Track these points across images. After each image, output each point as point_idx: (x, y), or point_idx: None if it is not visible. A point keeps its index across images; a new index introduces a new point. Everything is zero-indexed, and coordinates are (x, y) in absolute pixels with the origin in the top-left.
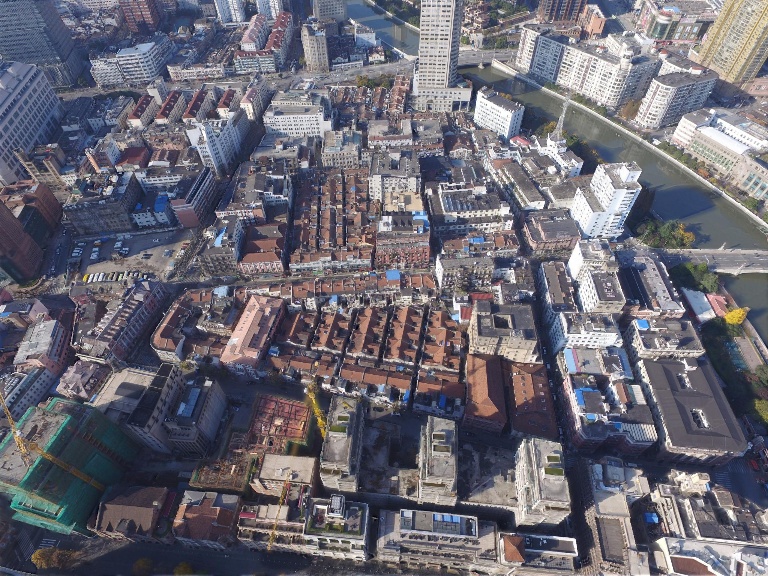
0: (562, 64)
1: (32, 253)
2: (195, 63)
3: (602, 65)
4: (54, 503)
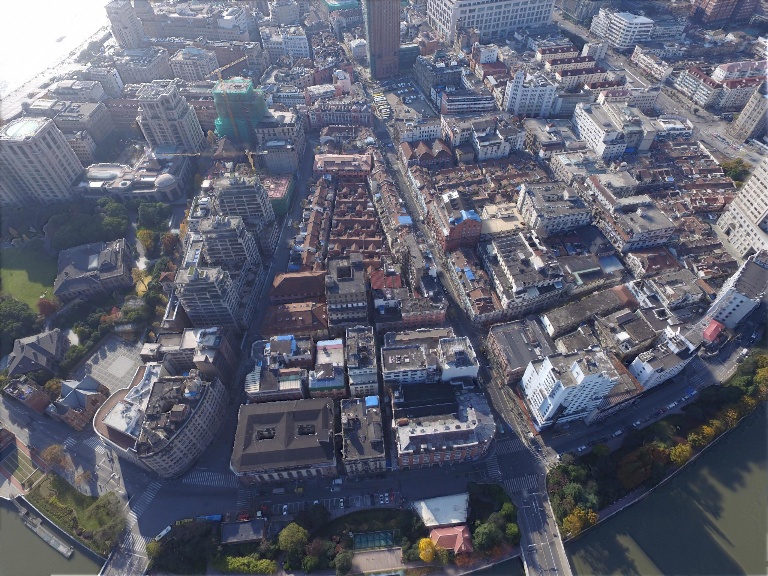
0: None
1: (389, 68)
2: (666, 58)
3: None
4: (218, 115)
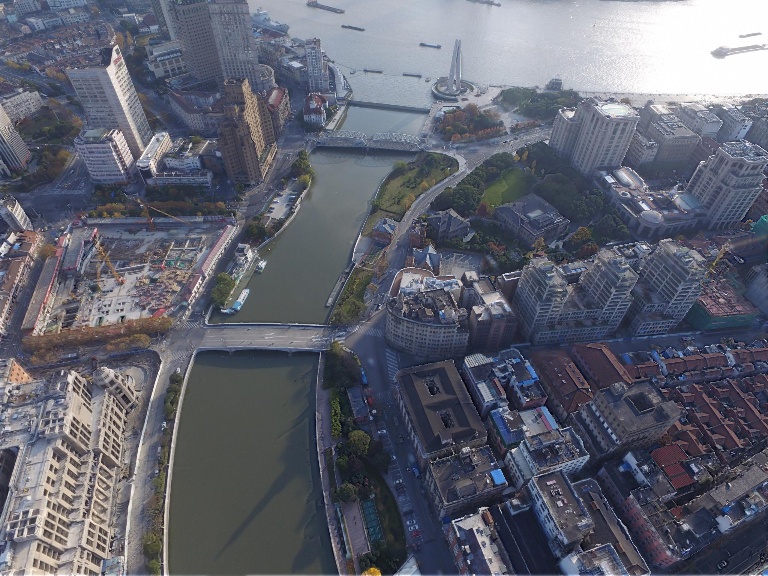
0: None
1: None
2: None
3: None
4: None
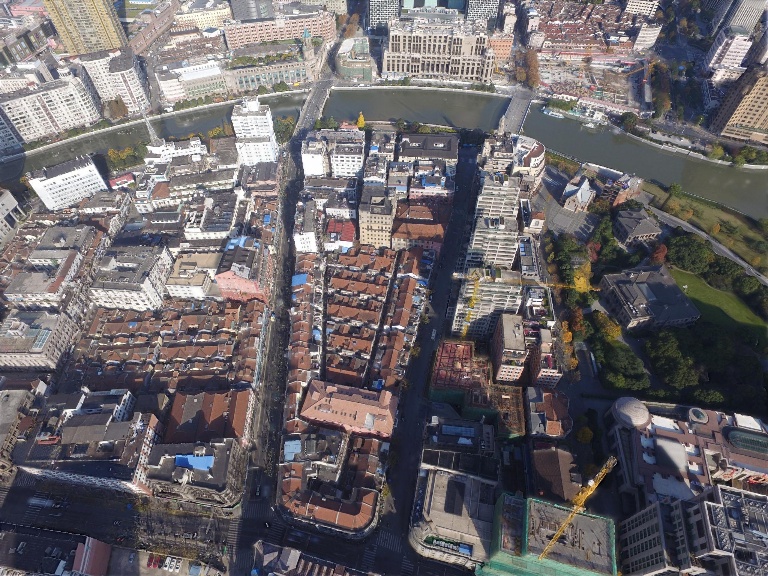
0: (13, 122)
1: None
2: None
3: (56, 94)
4: None
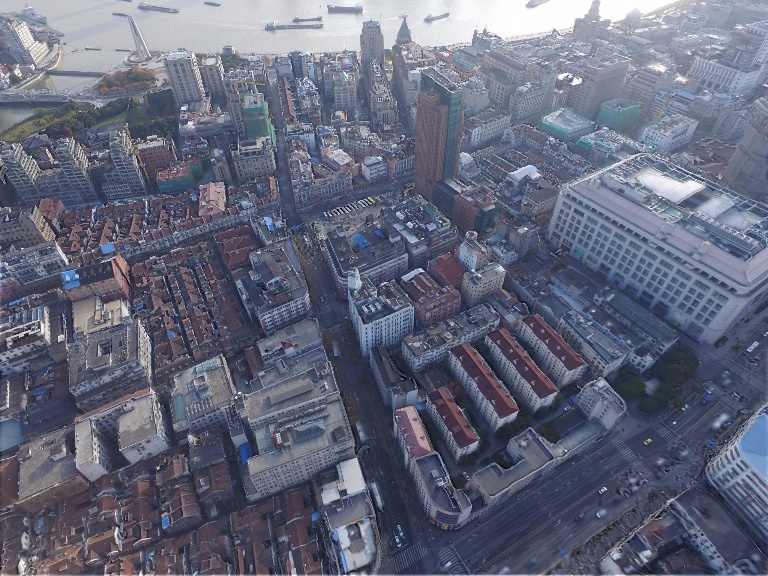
0: None
1: None
2: None
3: None
4: None
